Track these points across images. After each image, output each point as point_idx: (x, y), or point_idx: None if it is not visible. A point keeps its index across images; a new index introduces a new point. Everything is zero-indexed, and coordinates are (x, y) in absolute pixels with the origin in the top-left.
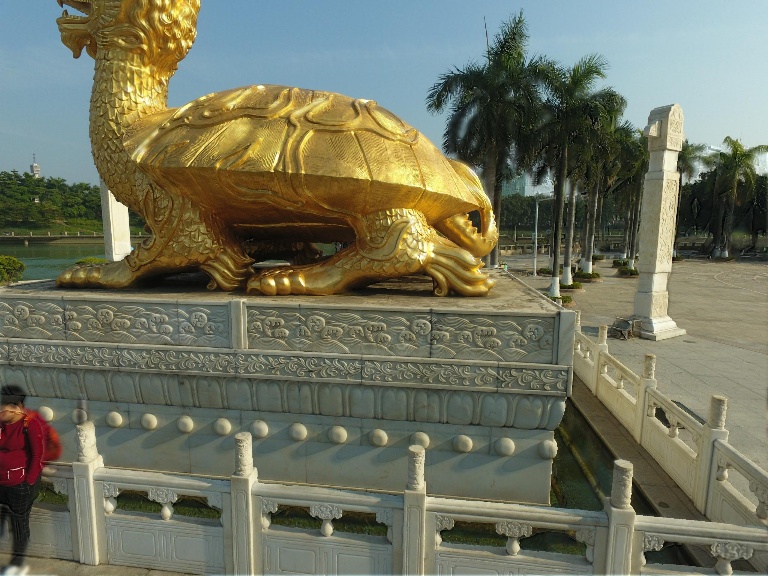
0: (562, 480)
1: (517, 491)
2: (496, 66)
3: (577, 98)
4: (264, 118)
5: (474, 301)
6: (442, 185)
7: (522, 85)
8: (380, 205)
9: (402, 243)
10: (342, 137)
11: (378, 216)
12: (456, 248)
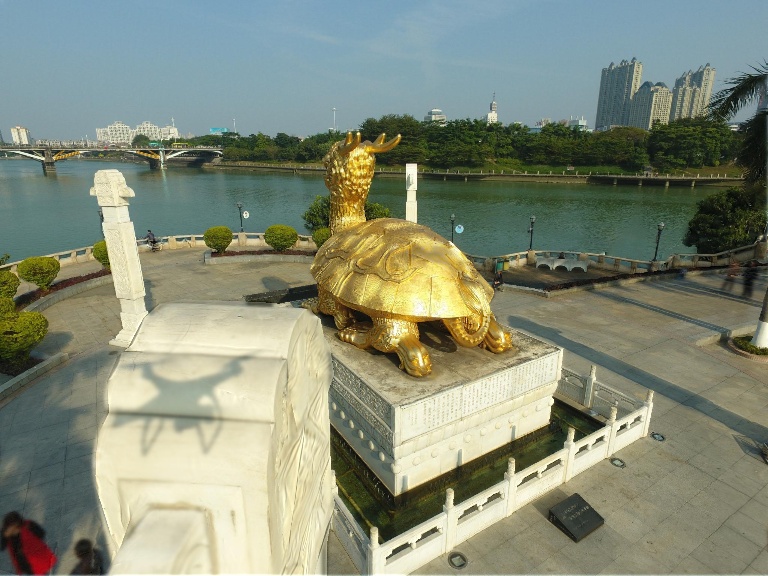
0: (443, 499)
1: (386, 480)
2: None
3: None
4: (343, 259)
5: (400, 379)
6: (408, 309)
7: None
8: (373, 315)
9: (382, 336)
10: (362, 278)
11: (374, 319)
12: (412, 345)
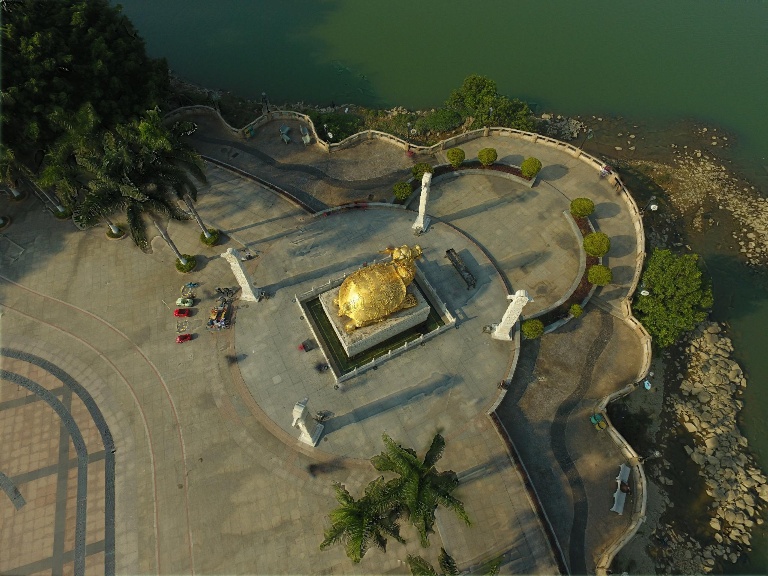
0: None
1: None
2: None
3: None
4: None
5: None
6: None
7: None
8: None
9: None
10: None
11: None
12: None
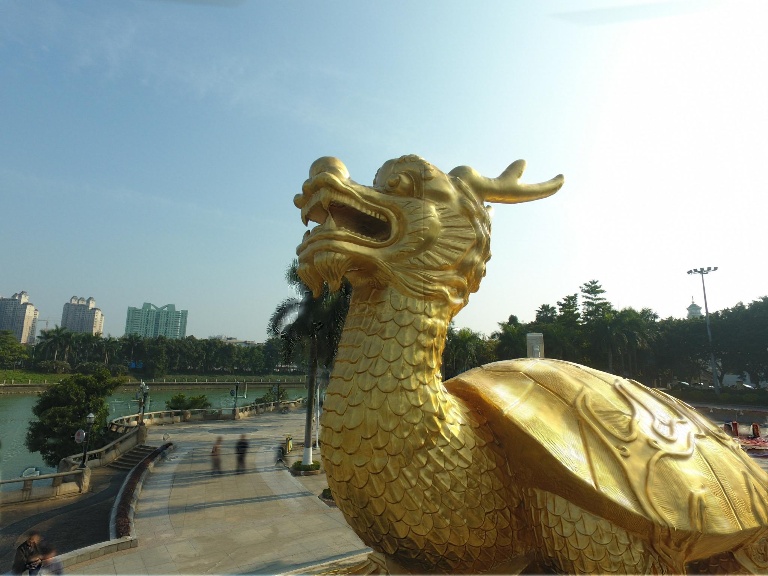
0: None
1: None
2: None
3: None
4: None
5: None
6: None
7: None
8: None
9: None
10: None
11: None
12: None
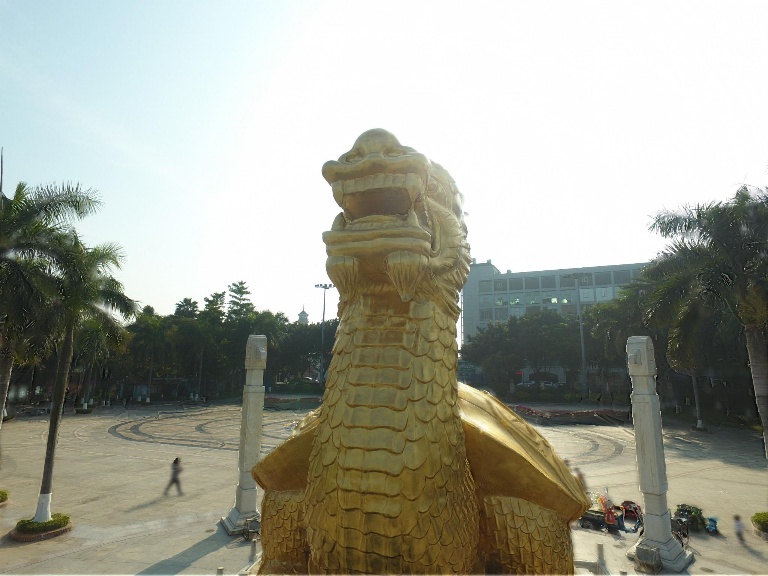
0: None
1: None
2: (23, 219)
3: (93, 280)
4: None
5: None
6: None
7: (75, 260)
8: None
9: None
10: None
11: None
12: None
